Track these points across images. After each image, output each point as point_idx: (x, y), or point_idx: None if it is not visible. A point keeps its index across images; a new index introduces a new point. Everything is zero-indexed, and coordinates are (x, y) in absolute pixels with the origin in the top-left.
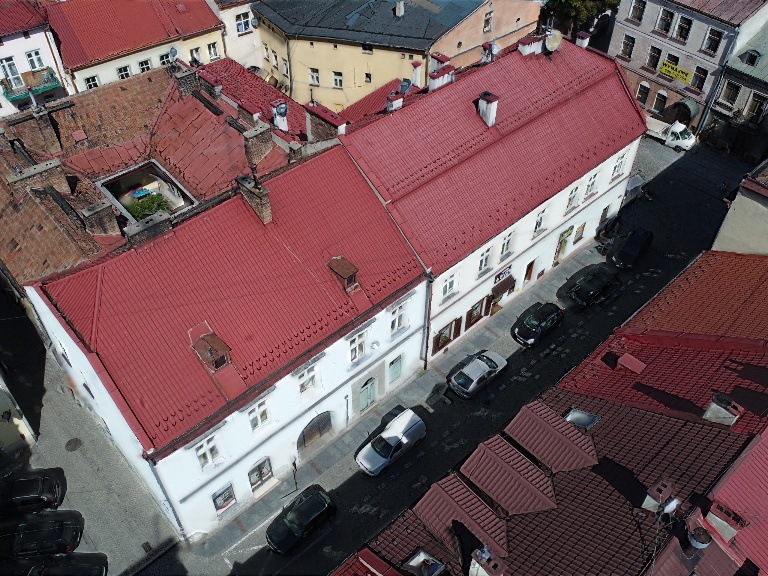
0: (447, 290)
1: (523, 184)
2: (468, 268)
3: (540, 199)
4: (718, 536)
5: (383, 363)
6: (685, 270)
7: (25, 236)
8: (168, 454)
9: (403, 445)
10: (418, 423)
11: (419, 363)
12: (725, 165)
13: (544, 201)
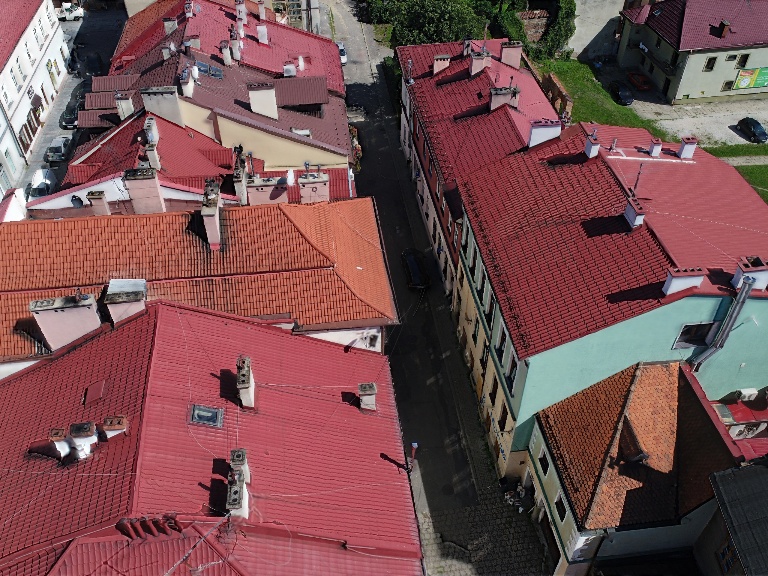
0: (6, 100)
1: (3, 27)
2: (8, 82)
3: (19, 32)
4: (196, 50)
5: (1, 153)
6: (124, 30)
7: None
8: None
9: (50, 186)
10: (49, 171)
11: (21, 161)
12: (111, 15)
13: (23, 33)
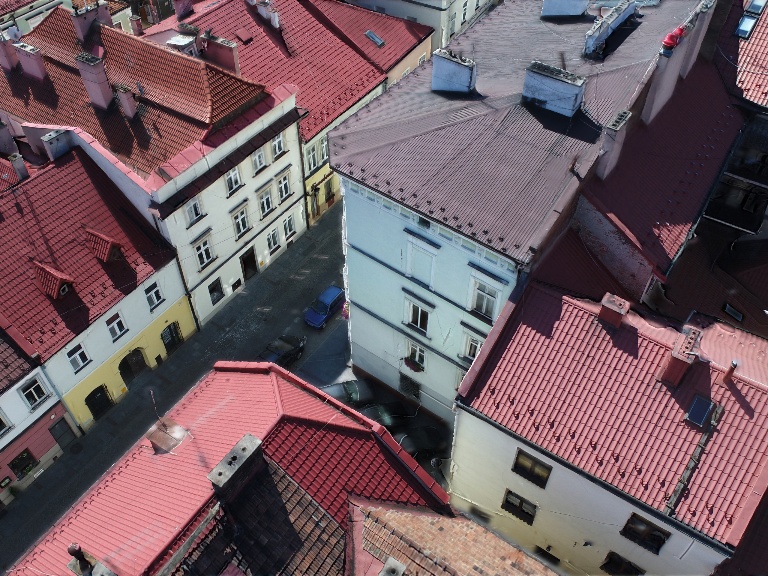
0: None
1: None
2: None
3: None
4: None
5: None
6: None
7: (505, 570)
8: (206, 376)
9: None
10: None
11: None
12: None
13: None
